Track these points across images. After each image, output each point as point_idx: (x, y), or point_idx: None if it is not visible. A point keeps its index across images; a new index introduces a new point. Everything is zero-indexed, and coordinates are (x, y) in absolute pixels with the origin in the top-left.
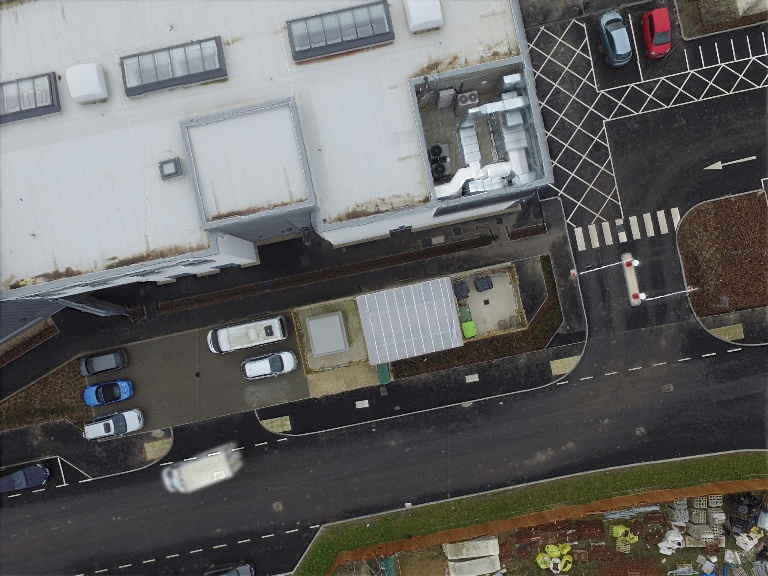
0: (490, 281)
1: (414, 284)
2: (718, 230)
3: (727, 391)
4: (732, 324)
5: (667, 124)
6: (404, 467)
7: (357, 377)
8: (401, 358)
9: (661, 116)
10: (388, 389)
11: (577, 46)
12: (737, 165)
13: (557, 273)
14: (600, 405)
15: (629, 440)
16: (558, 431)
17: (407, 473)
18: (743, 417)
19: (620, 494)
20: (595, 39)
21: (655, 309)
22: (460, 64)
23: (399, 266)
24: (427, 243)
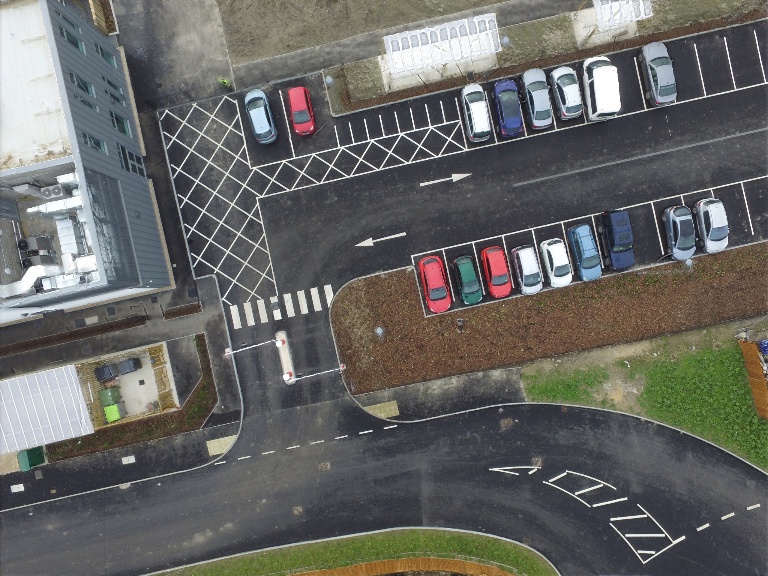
0: (132, 364)
1: (38, 372)
2: (369, 307)
3: (384, 468)
4: (387, 401)
5: (319, 201)
6: (61, 551)
7: (11, 461)
8: (31, 447)
9: (313, 193)
10: (43, 472)
11: (229, 123)
12: (387, 241)
13: (212, 352)
14: (258, 485)
15: (287, 520)
16: (216, 512)
17: (65, 557)
18: (400, 494)
19: (277, 575)
20: (247, 115)
21: (310, 387)
22: (15, 163)
23: (52, 347)
24: (80, 323)
